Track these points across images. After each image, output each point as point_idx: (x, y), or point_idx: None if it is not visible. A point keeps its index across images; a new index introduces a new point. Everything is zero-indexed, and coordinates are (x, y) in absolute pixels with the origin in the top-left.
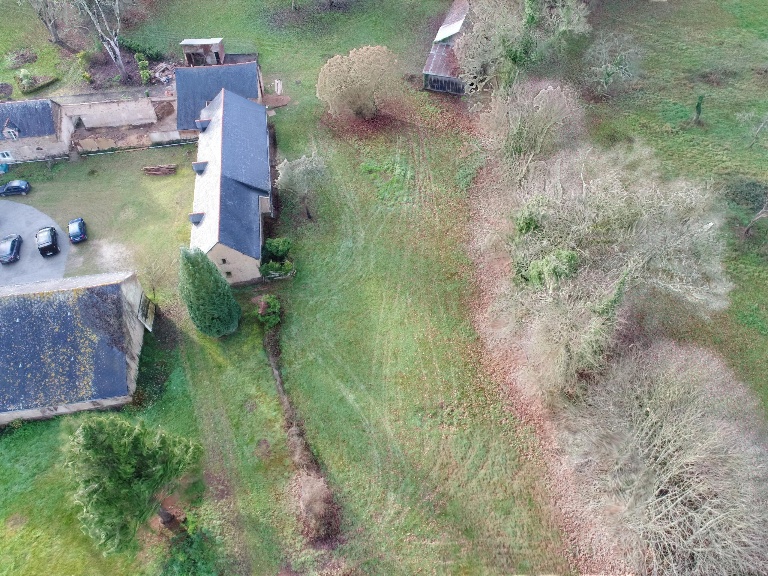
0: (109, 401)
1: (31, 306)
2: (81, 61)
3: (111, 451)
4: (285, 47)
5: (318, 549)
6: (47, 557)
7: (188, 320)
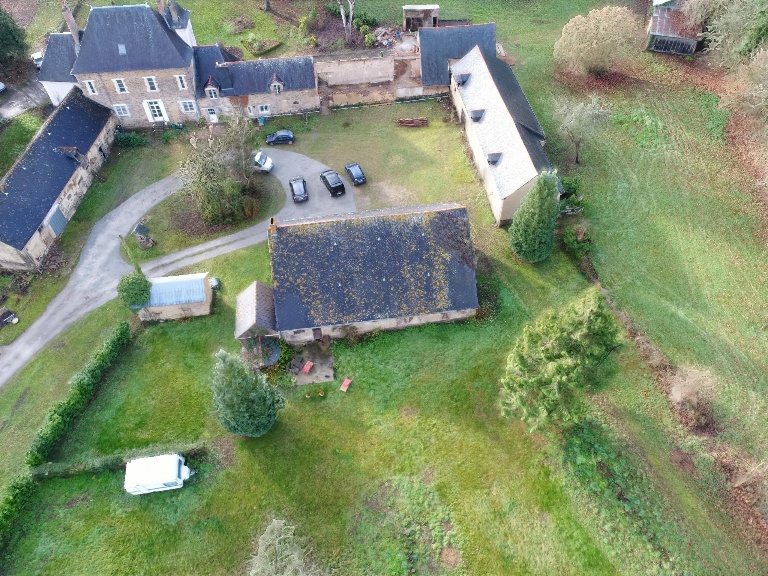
0: (457, 314)
1: (390, 227)
2: (303, 26)
3: (606, 322)
4: (492, 14)
5: (700, 436)
6: (450, 440)
7: (494, 249)
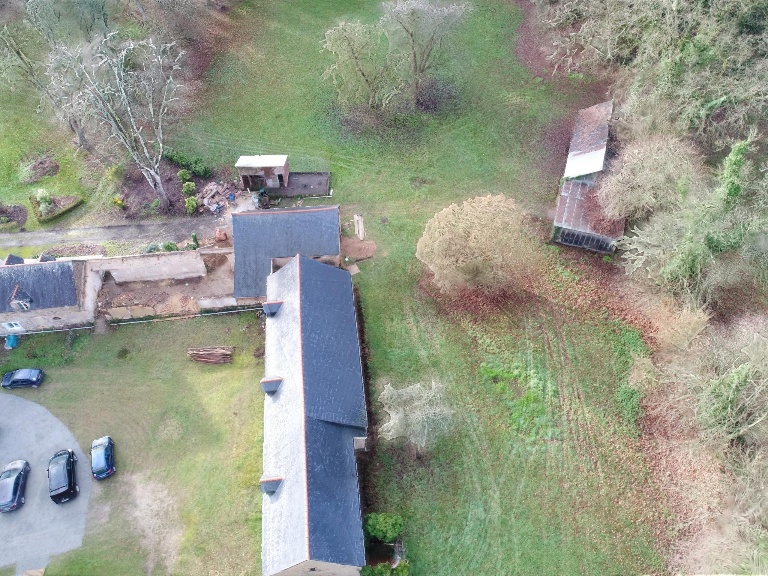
0: None
1: None
2: (112, 179)
3: None
4: (363, 164)
5: None
6: None
7: None
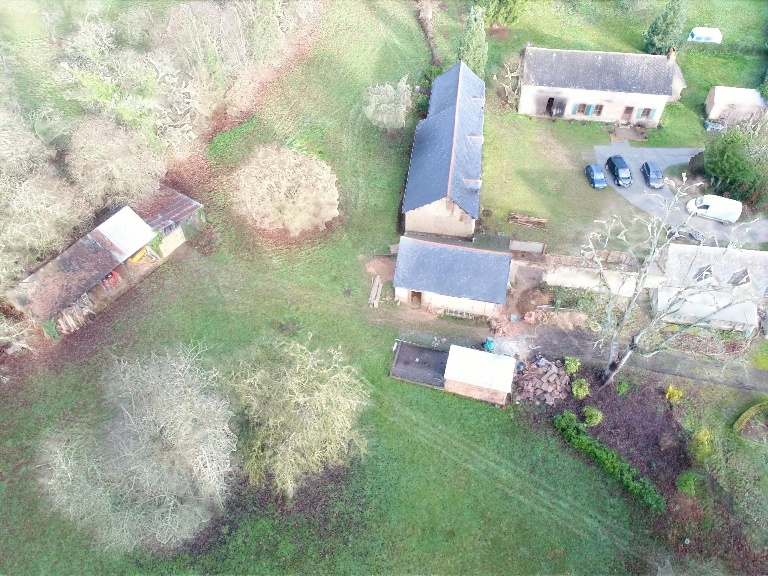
0: None
1: None
2: None
3: None
4: None
5: None
6: (549, 29)
7: (489, 97)
